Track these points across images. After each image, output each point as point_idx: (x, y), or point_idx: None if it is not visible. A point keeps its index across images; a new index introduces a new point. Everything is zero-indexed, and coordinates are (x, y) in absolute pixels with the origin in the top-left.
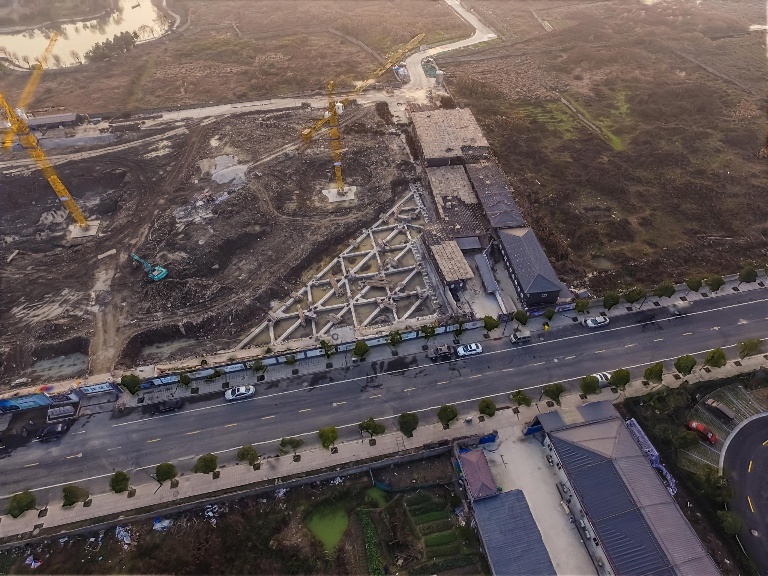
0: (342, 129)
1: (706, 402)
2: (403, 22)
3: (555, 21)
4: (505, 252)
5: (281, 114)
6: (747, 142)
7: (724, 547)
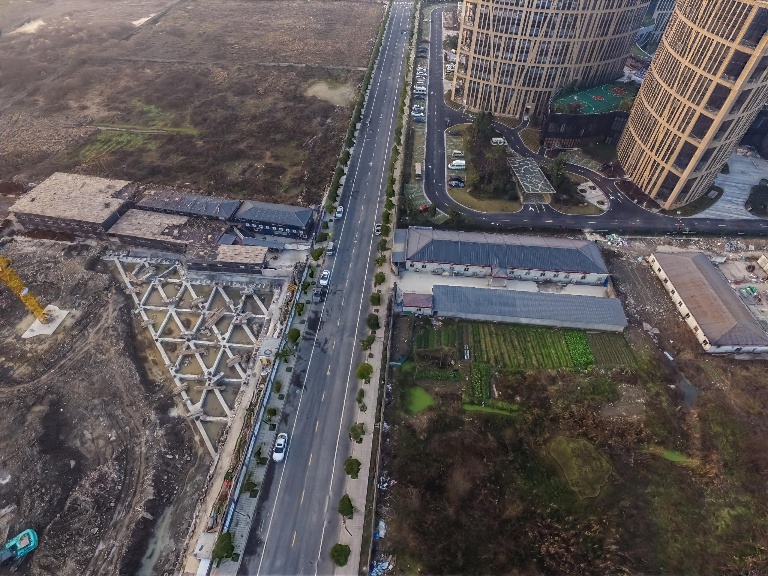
0: None
1: (410, 199)
2: None
3: None
4: (256, 224)
5: None
6: (247, 89)
7: (478, 231)
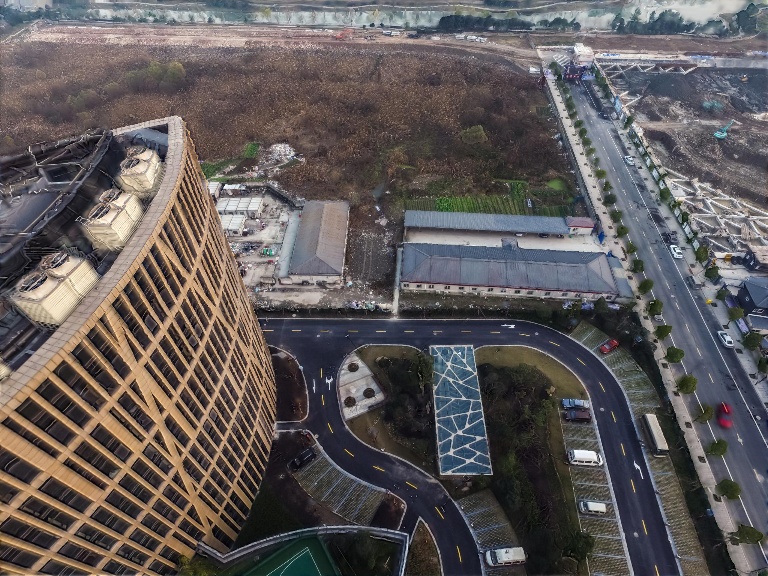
0: None
1: None
2: None
3: None
4: None
5: None
6: None
7: None
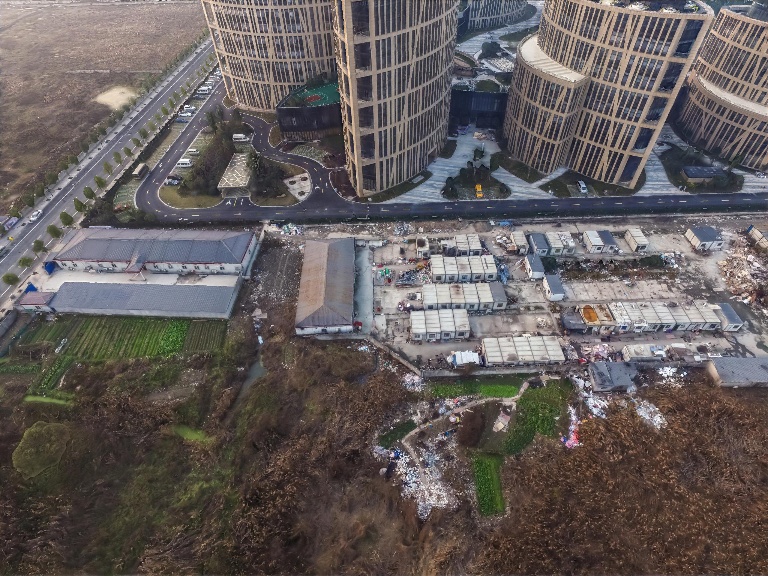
0: None
1: (114, 199)
2: None
3: None
4: None
5: None
6: (33, 98)
7: (159, 227)
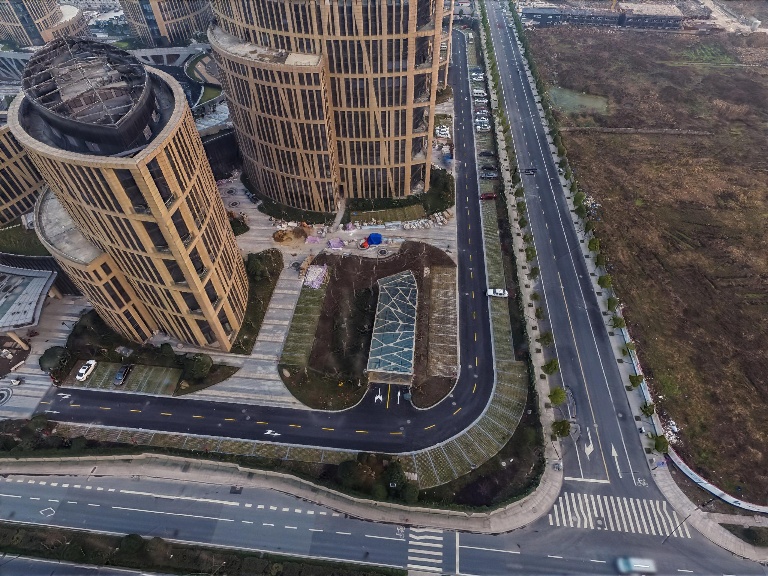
0: None
1: None
2: None
3: None
4: None
5: None
6: None
7: None
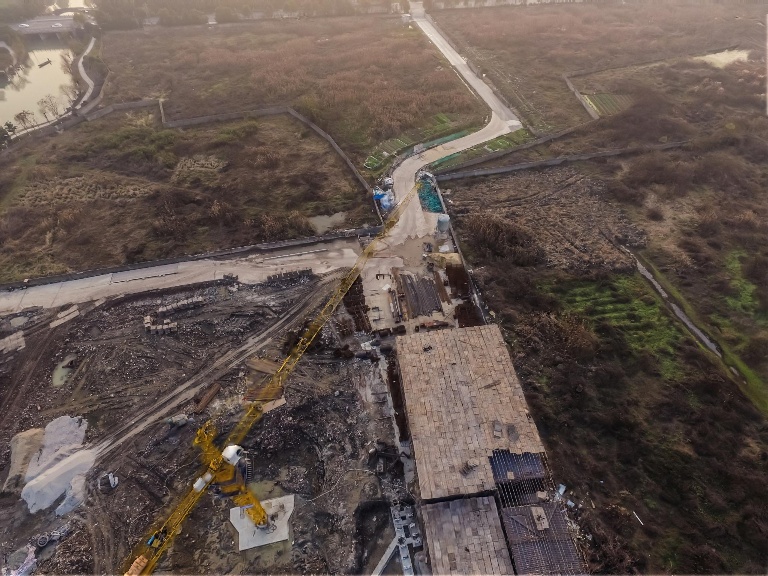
0: (282, 340)
1: None
2: (391, 101)
3: (599, 96)
4: None
5: (185, 304)
6: None
7: None
